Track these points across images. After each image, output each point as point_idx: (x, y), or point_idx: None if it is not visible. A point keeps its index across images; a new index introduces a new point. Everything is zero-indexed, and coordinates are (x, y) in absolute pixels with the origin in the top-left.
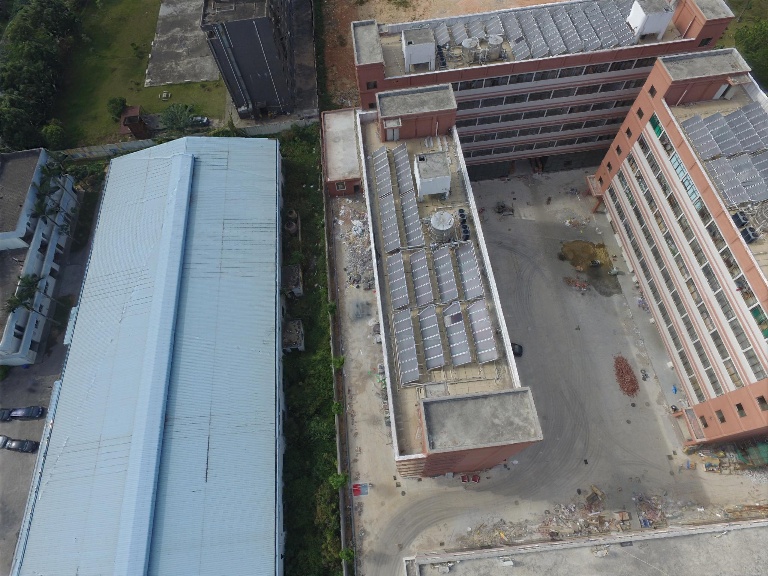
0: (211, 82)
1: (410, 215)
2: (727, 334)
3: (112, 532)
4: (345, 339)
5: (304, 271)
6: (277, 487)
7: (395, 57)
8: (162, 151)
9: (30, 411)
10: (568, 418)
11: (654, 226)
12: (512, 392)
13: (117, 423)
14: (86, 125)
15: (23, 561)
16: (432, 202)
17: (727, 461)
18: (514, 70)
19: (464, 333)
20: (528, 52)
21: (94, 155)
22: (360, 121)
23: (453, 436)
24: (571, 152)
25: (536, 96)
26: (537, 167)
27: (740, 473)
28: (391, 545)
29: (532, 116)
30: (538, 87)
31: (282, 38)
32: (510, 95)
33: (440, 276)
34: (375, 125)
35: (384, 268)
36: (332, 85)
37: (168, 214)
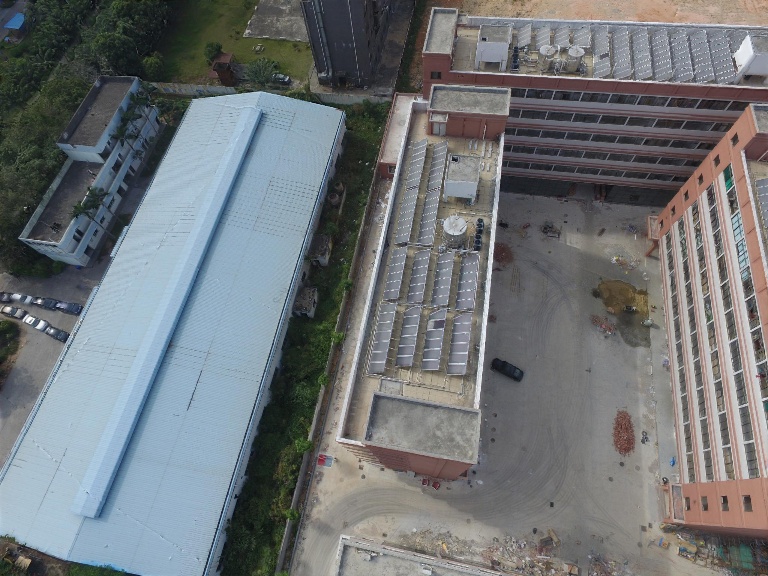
0: (303, 43)
1: (429, 213)
2: (734, 420)
3: (100, 428)
4: (354, 317)
5: (335, 243)
6: (247, 434)
7: (469, 51)
8: (237, 101)
9: (71, 306)
10: (548, 456)
11: (697, 285)
12: (463, 410)
13: (130, 336)
14: (184, 63)
15: (29, 429)
16: (456, 205)
17: (706, 552)
18: (588, 87)
19: (441, 341)
20: (609, 71)
21: (183, 92)
22: (413, 109)
23: (392, 434)
24: (640, 187)
25: (609, 119)
26: (600, 194)
27: (717, 569)
28: (337, 520)
29: (602, 140)
30: (613, 110)
31: (377, 12)
32: (580, 113)
33: (438, 279)
34: (426, 116)
35: (388, 258)
36: (416, 67)
37: (224, 161)
